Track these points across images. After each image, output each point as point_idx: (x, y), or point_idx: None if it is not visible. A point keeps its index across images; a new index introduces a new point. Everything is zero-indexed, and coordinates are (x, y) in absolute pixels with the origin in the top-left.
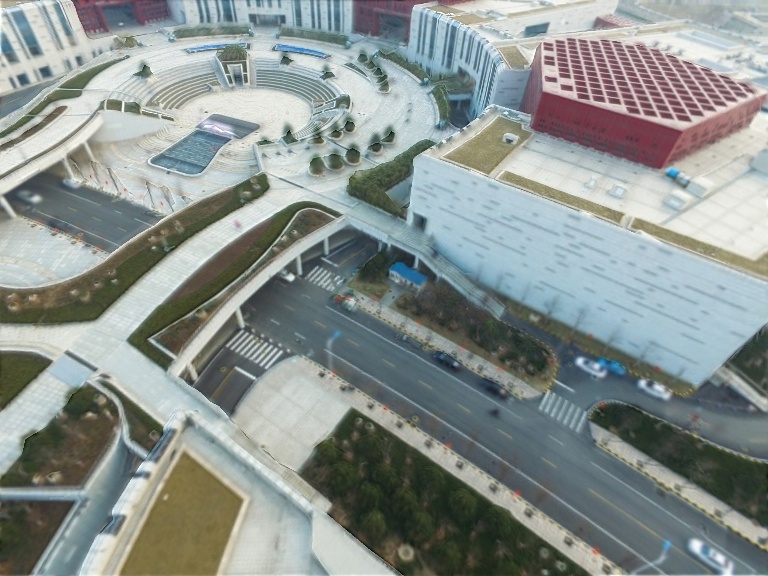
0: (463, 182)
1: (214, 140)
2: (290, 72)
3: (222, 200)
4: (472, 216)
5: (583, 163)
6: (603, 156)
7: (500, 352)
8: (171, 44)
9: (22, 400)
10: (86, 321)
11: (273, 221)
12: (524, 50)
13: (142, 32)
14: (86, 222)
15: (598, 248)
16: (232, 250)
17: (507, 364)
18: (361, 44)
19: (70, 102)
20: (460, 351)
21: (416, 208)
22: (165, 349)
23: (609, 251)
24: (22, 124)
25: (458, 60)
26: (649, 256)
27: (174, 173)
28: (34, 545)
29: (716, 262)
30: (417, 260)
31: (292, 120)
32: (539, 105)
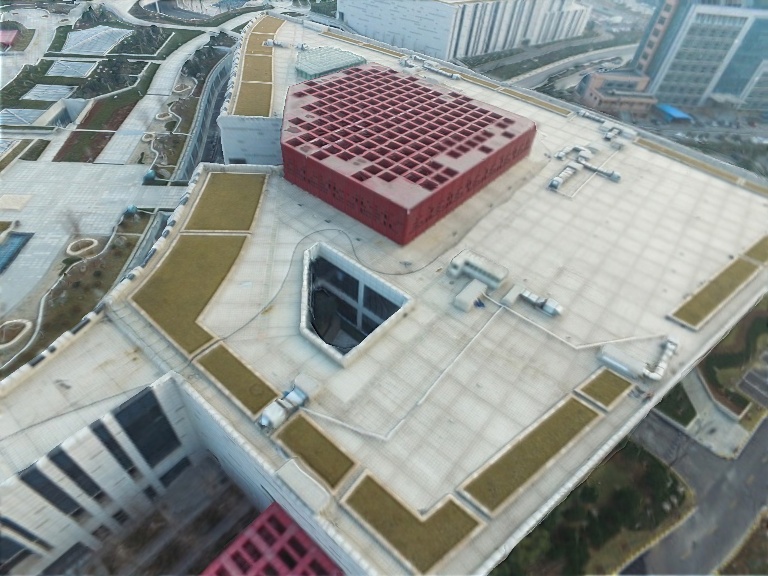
0: None
1: (242, 0)
2: None
3: (255, 8)
4: (361, 5)
5: None
6: None
7: None
8: None
9: None
10: (213, 27)
11: None
12: None
13: None
14: None
15: (403, 6)
16: None
17: None
18: None
19: None
20: None
21: (340, 9)
22: None
23: (406, 6)
24: None
25: None
26: (417, 4)
27: None
28: (220, 56)
29: (435, 1)
30: None
31: None
32: None
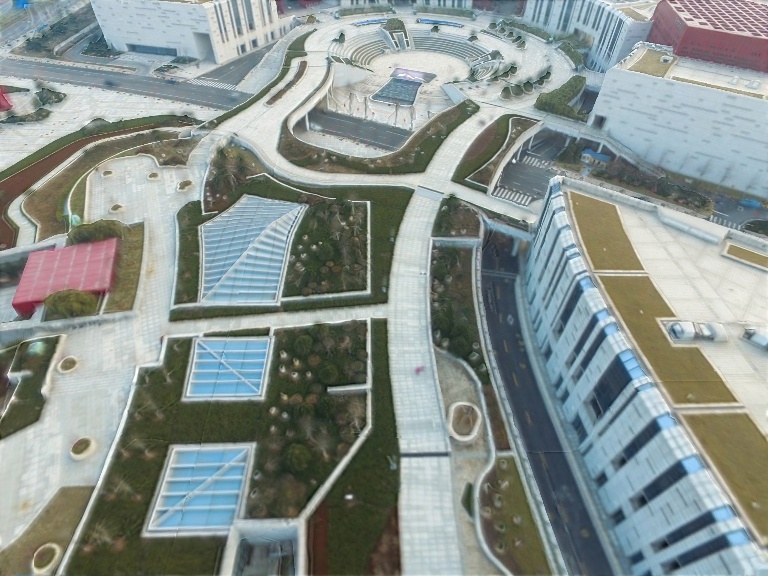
0: (645, 84)
1: (410, 84)
2: (440, 38)
3: (455, 113)
4: (647, 109)
5: (721, 73)
6: (733, 69)
7: (674, 196)
8: (338, 21)
9: (413, 205)
10: (419, 173)
11: (498, 123)
12: (637, 10)
13: (309, 13)
14: (356, 133)
15: (747, 117)
16: (484, 138)
17: (681, 202)
18: (482, 17)
19: (304, 59)
20: (646, 197)
21: (599, 111)
22: (479, 183)
23: (755, 118)
24: (287, 72)
25: (575, 23)
26: None
27: (394, 105)
28: (466, 261)
29: None
30: (601, 146)
31: (457, 71)
32: (683, 37)
